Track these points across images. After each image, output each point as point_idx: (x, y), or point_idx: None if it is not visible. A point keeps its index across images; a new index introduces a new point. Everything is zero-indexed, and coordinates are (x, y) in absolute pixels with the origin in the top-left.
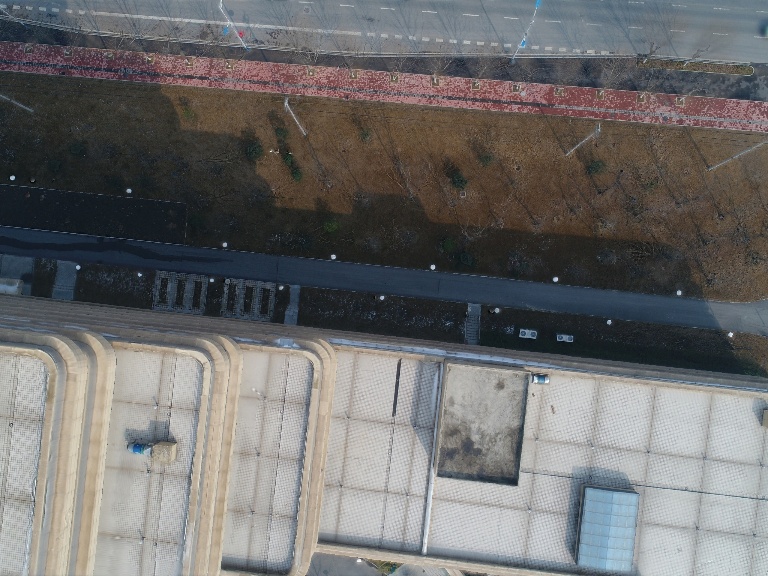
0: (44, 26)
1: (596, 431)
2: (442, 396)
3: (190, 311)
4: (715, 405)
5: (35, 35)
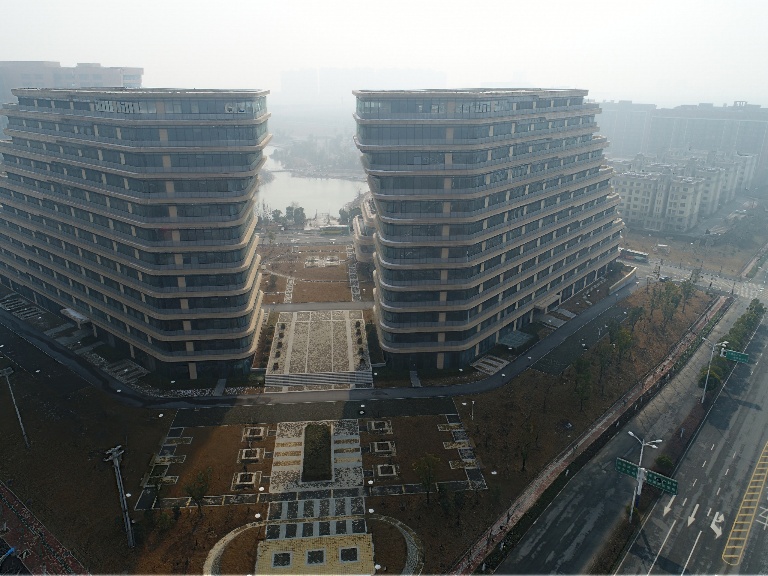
0: None
1: None
2: None
3: (36, 308)
4: None
5: None
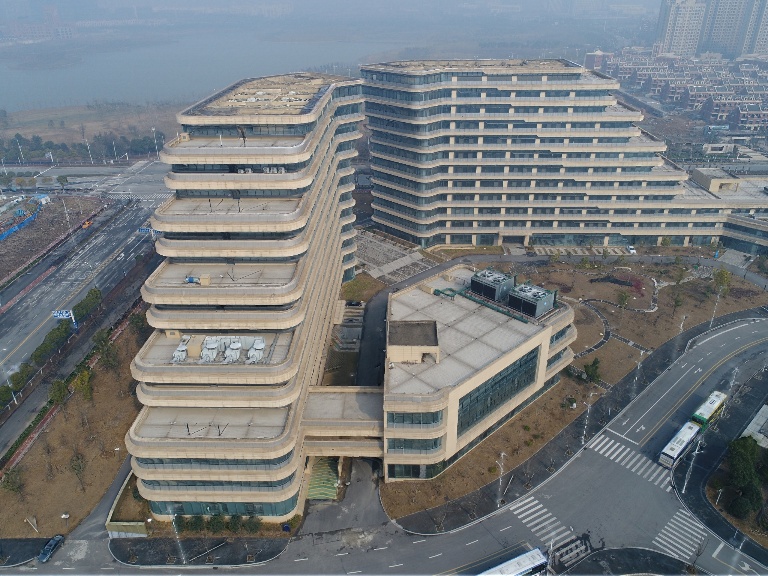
0: None
1: None
2: (698, 174)
3: None
4: None
5: None
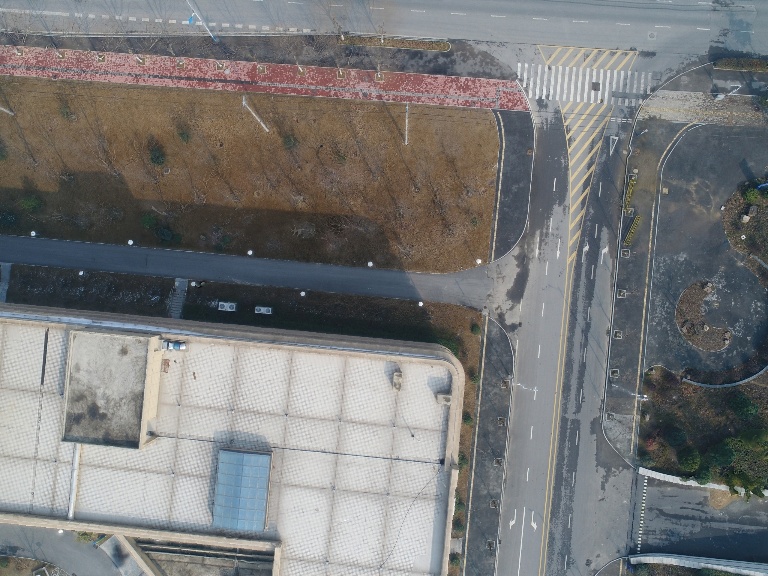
0: None
1: (236, 396)
2: None
3: None
4: (349, 368)
5: None
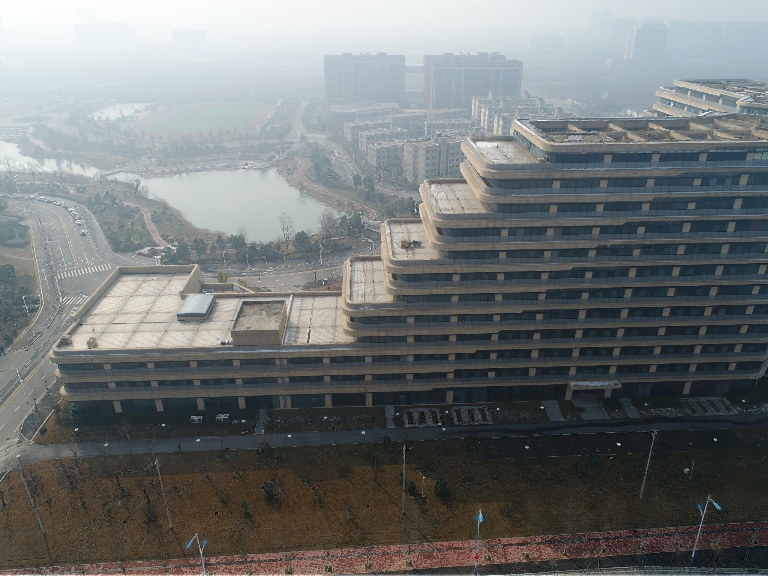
0: (679, 568)
1: None
2: None
3: (461, 408)
4: None
5: (682, 559)
